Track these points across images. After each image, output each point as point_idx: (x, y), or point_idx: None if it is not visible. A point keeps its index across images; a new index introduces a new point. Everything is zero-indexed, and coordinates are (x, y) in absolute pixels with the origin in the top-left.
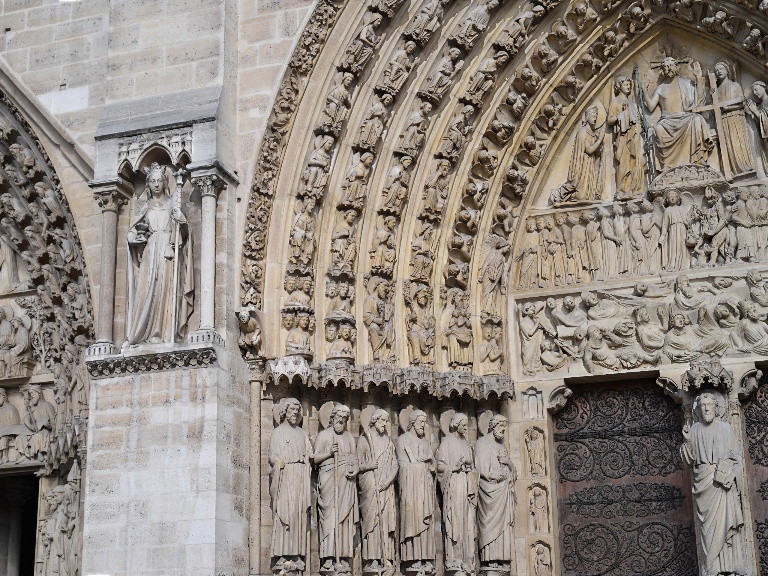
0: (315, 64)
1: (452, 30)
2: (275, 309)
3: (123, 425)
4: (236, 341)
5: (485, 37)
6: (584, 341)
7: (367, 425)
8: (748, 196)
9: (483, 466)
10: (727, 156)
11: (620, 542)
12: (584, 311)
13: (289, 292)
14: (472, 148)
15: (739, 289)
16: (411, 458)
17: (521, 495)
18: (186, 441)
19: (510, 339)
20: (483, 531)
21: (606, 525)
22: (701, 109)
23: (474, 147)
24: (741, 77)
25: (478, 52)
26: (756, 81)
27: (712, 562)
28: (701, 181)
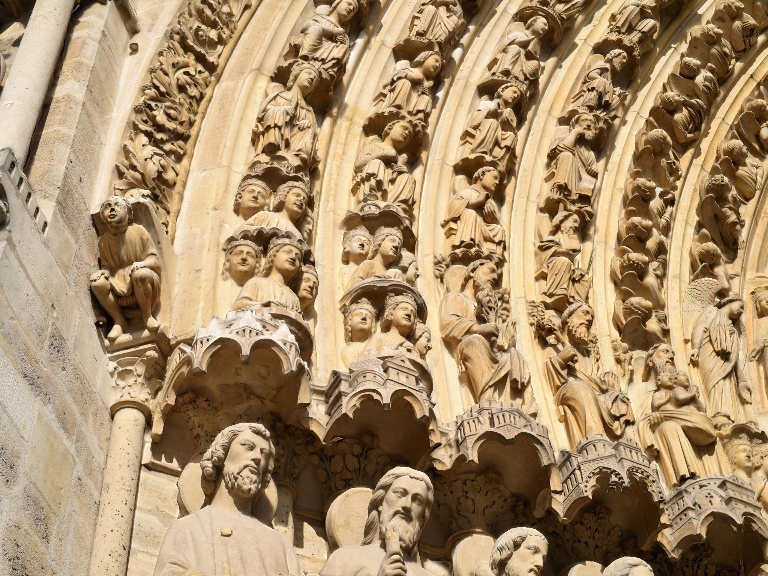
0: None
1: None
2: (206, 242)
3: None
4: (82, 274)
5: None
6: None
7: None
8: None
9: None
10: None
11: None
12: None
13: (247, 216)
14: (628, 133)
15: None
16: None
17: None
18: None
19: None
20: None
21: None
22: None
23: (632, 133)
24: None
25: None
26: None
27: None
28: None
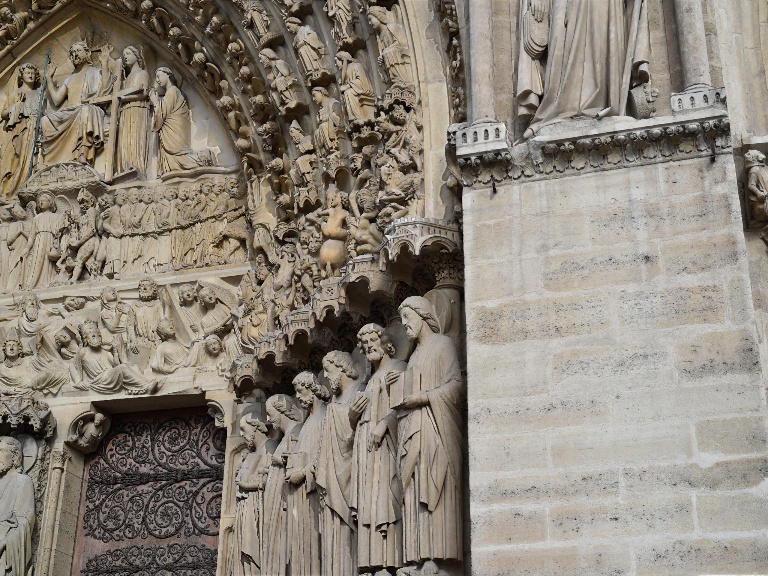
0: None
1: None
2: None
3: None
4: None
5: None
6: None
7: None
8: (125, 200)
9: None
10: (111, 153)
11: None
12: None
13: None
14: None
15: (89, 311)
16: None
17: None
18: None
19: None
20: None
21: None
22: (98, 100)
23: None
24: (157, 66)
25: None
26: (161, 67)
27: None
28: (76, 182)
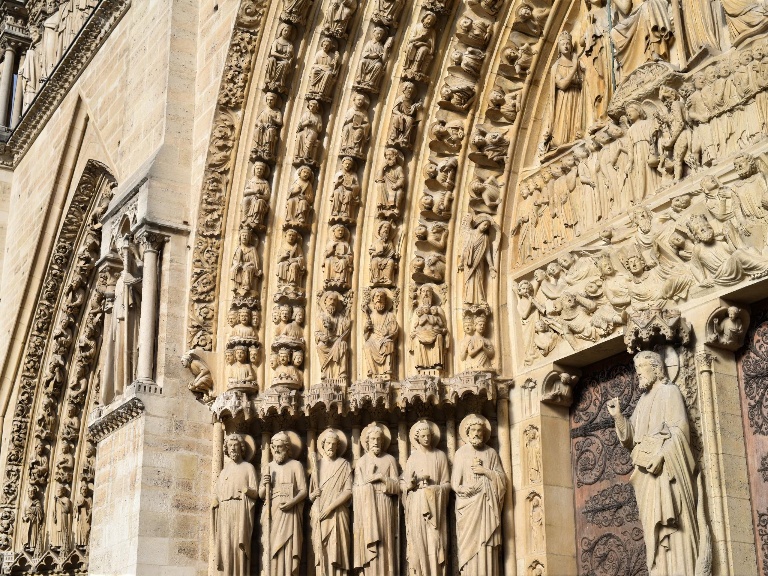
0: (248, 94)
1: (373, 10)
2: (222, 347)
3: (106, 482)
4: (186, 386)
5: (413, 3)
6: None
7: (324, 451)
8: (703, 82)
9: (455, 479)
10: (680, 39)
11: (629, 555)
12: None
13: (233, 327)
14: None
15: (695, 206)
16: (359, 480)
17: (521, 508)
18: (129, 490)
19: (510, 327)
20: (458, 555)
21: (616, 535)
22: None
23: None
24: None
25: (409, 22)
26: None
27: (649, 573)
28: (654, 82)
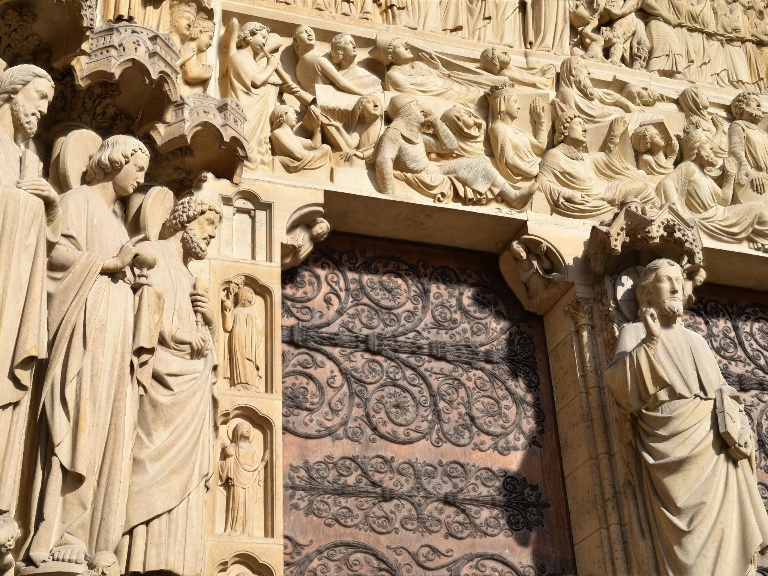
0: None
1: None
2: None
3: None
4: None
5: None
6: (378, 123)
7: None
8: None
9: None
10: None
11: None
12: (373, 73)
13: None
14: None
15: (671, 112)
16: (0, 172)
17: None
18: None
19: None
20: (134, 481)
21: (377, 548)
22: None
23: None
24: None
25: None
26: None
27: None
28: None
